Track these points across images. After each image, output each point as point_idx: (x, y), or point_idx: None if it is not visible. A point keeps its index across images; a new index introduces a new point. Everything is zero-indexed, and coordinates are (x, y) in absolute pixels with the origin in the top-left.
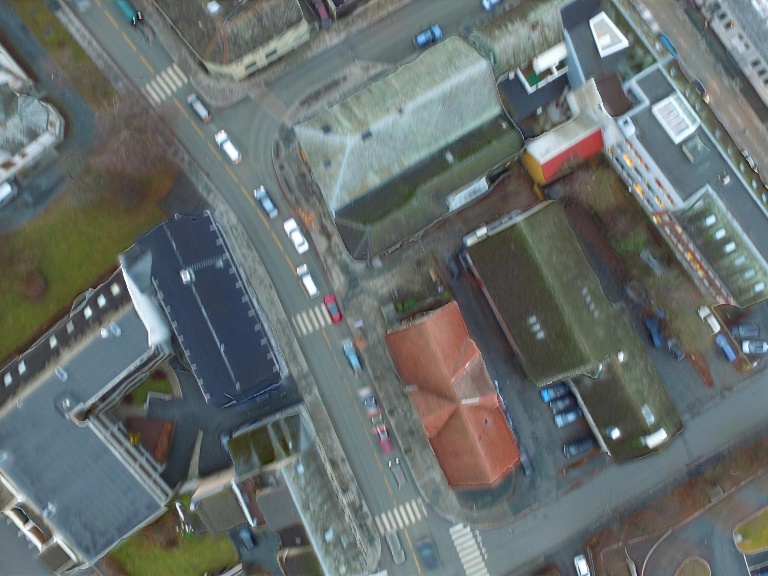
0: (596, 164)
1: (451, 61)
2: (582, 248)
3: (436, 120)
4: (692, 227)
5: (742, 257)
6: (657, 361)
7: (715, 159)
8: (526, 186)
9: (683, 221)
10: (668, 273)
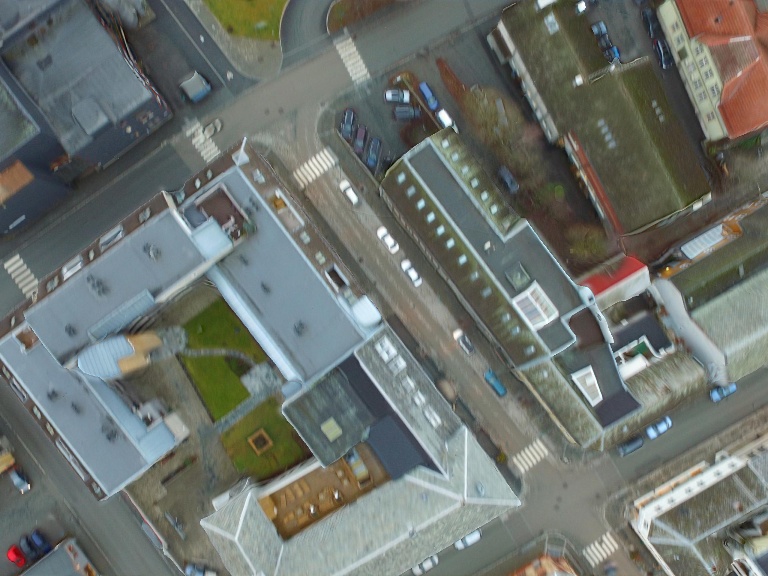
0: (574, 272)
1: (748, 356)
2: (570, 196)
3: (762, 303)
4: (506, 205)
5: (465, 173)
6: (496, 85)
7: (497, 266)
8: (631, 254)
9: (513, 211)
10: (493, 169)
